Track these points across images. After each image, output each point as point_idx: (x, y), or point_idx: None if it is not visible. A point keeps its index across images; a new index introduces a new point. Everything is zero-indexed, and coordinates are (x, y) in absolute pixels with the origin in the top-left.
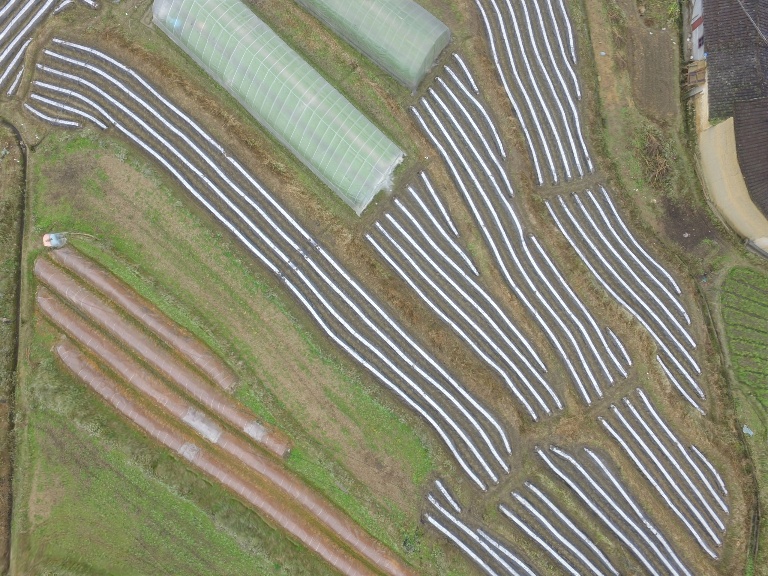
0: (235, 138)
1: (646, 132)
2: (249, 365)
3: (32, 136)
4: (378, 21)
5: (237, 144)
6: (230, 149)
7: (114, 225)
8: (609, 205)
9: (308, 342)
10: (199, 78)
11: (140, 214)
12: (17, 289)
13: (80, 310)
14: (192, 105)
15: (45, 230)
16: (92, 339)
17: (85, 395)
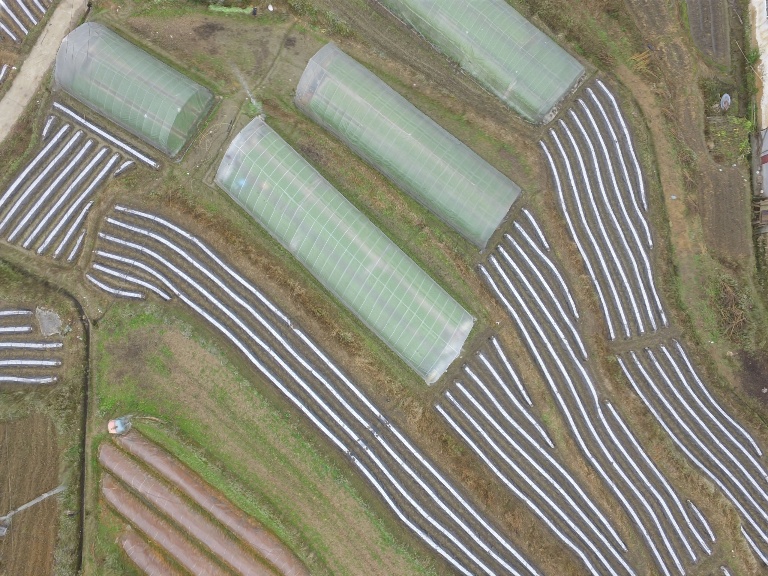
0: (302, 309)
1: (721, 281)
2: (319, 555)
3: (95, 310)
4: (449, 186)
5: (304, 316)
6: (297, 320)
7: (179, 405)
8: (684, 361)
9: (380, 529)
10: (262, 240)
11: (206, 393)
12: (81, 478)
13: (145, 499)
14: (258, 275)
15: (109, 412)
16: (158, 532)
17: None
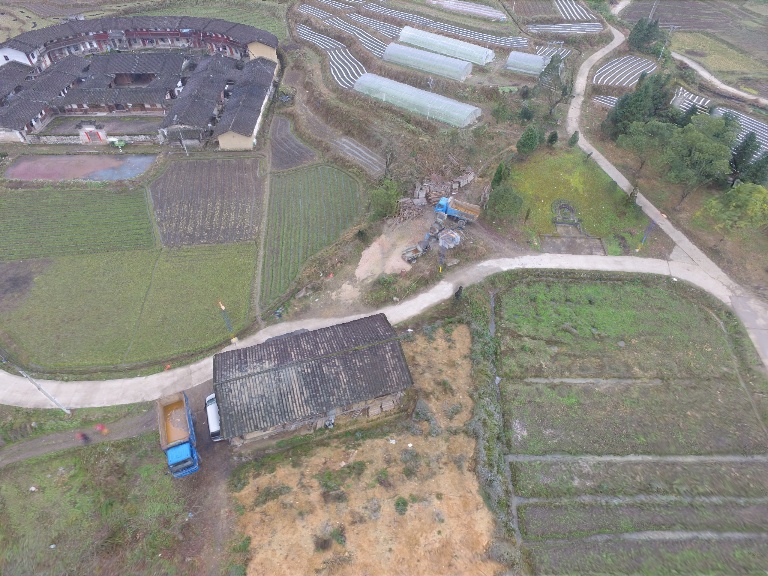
0: (456, 36)
1: None
2: None
3: None
4: None
5: None
6: None
7: None
8: None
9: None
10: None
11: None
12: None
13: None
14: None
15: None
16: (484, 9)
17: (482, 4)
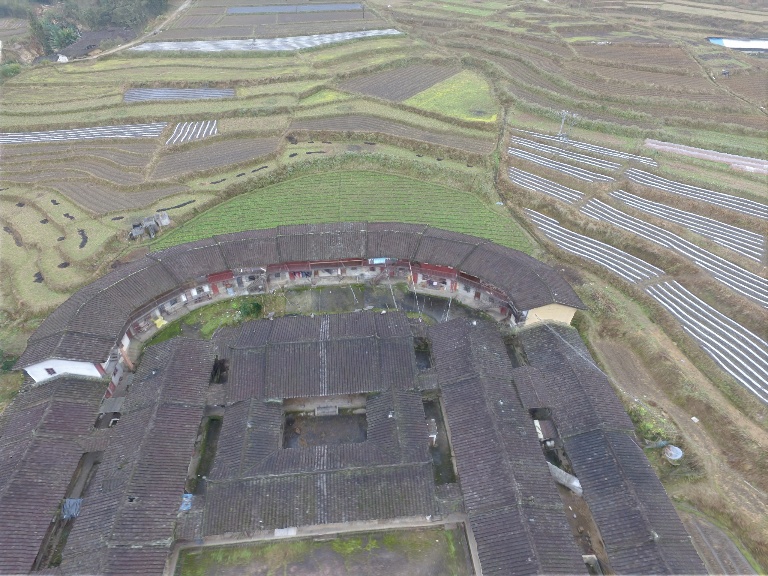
0: None
1: None
2: None
3: None
4: None
5: None
6: None
7: None
8: None
9: None
10: None
11: None
12: None
13: None
14: None
15: None
16: None
17: None
